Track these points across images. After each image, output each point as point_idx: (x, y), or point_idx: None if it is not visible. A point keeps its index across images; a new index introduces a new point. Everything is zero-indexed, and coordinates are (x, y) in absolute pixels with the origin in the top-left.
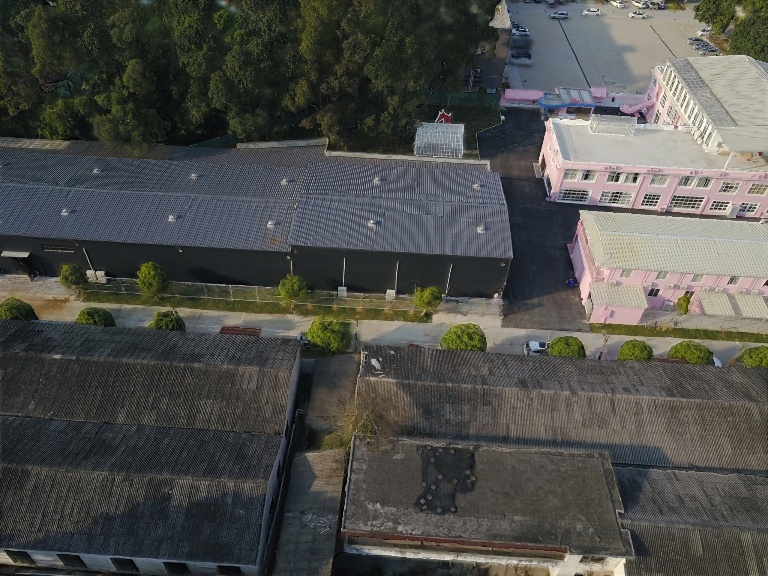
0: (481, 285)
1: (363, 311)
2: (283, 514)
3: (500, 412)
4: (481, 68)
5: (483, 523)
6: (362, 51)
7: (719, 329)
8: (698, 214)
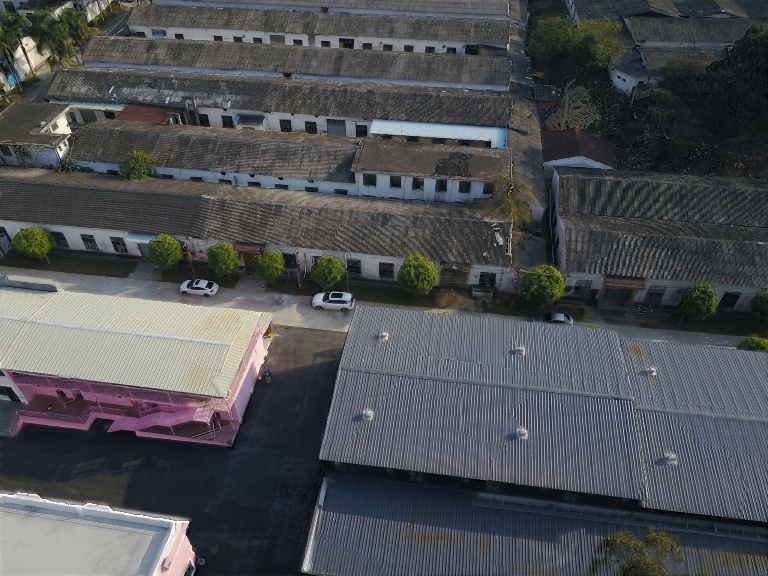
0: None
1: None
2: None
3: None
4: None
5: (436, 149)
6: None
7: None
8: None
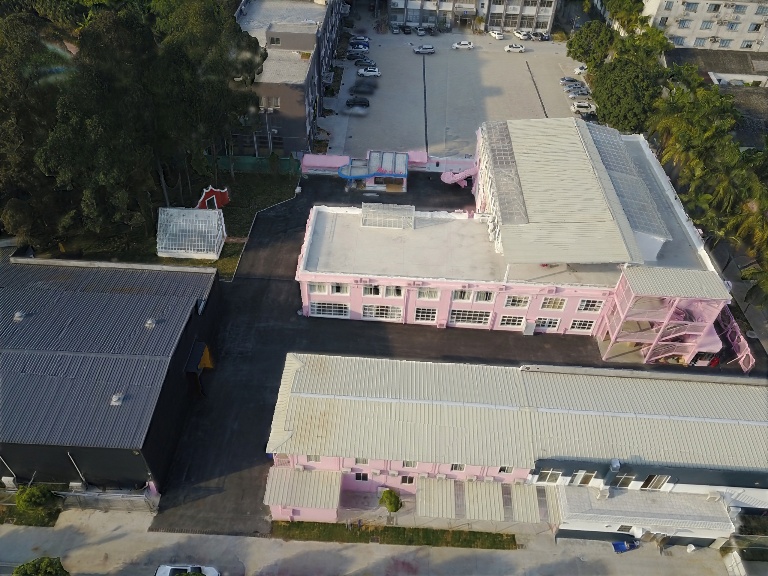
0: (124, 472)
1: None
2: None
3: None
4: (278, 128)
5: None
6: (8, 142)
7: (446, 527)
8: (488, 330)
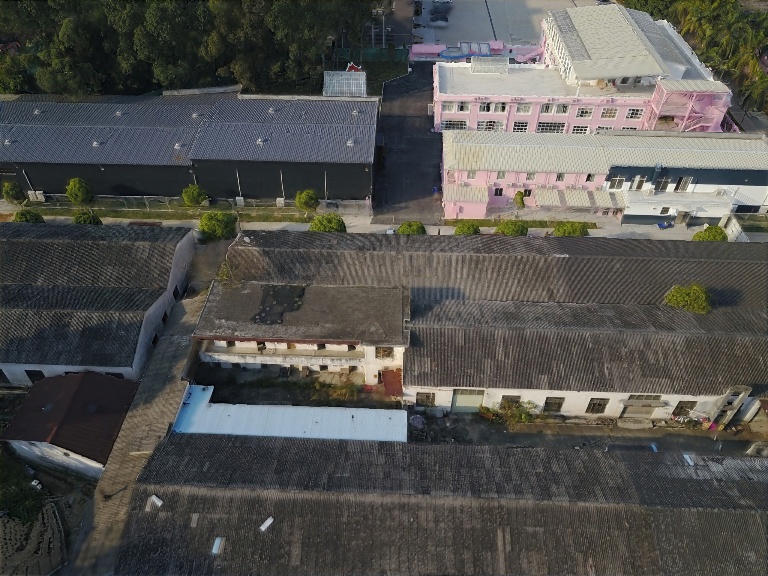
0: (353, 190)
1: (257, 216)
2: (159, 338)
3: (339, 268)
4: (391, 27)
5: (300, 329)
6: (257, 3)
7: (552, 220)
8: None
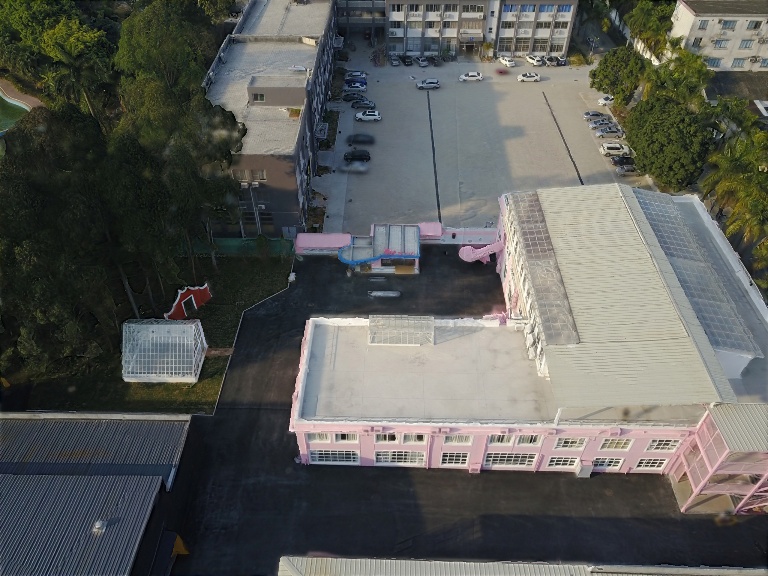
0: None
1: None
2: None
3: None
4: (266, 203)
5: None
6: None
7: None
8: (532, 472)
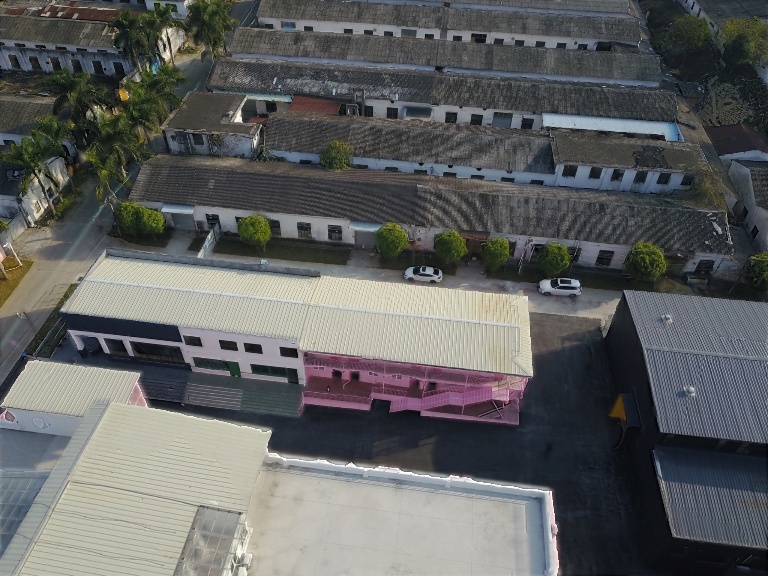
0: None
1: None
2: None
3: None
4: None
5: (626, 142)
6: None
7: None
8: None
